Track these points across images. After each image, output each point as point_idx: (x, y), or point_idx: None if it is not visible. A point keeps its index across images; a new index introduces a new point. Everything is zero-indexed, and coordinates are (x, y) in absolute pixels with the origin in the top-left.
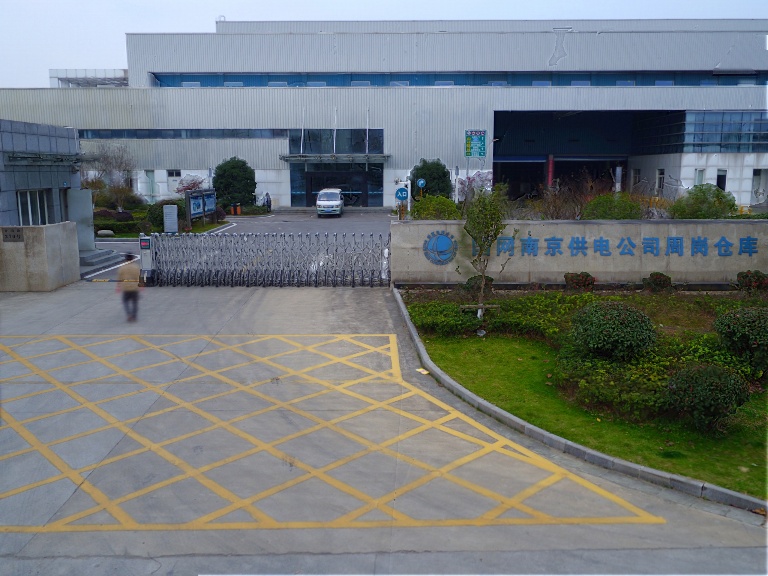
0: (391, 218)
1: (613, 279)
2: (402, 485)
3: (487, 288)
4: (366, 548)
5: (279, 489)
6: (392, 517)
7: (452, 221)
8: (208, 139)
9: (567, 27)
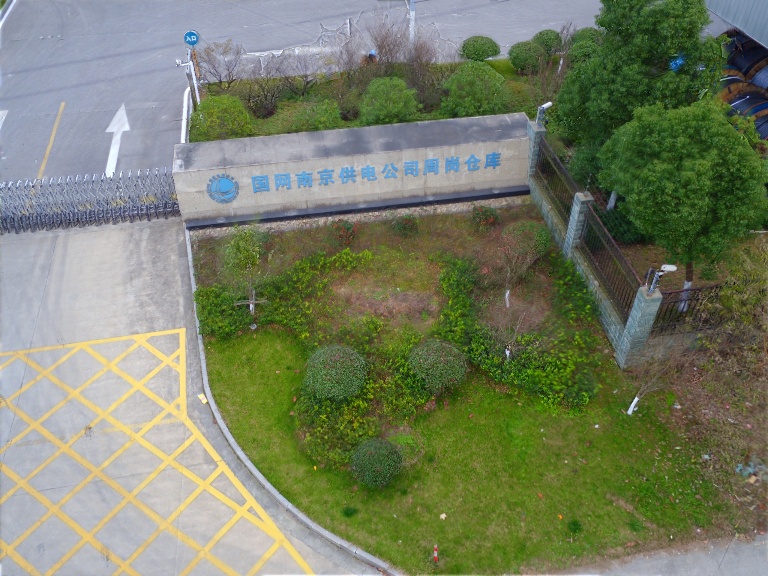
0: None
1: (379, 198)
2: (179, 573)
3: (263, 250)
4: None
5: None
6: None
7: (233, 150)
8: None
9: None
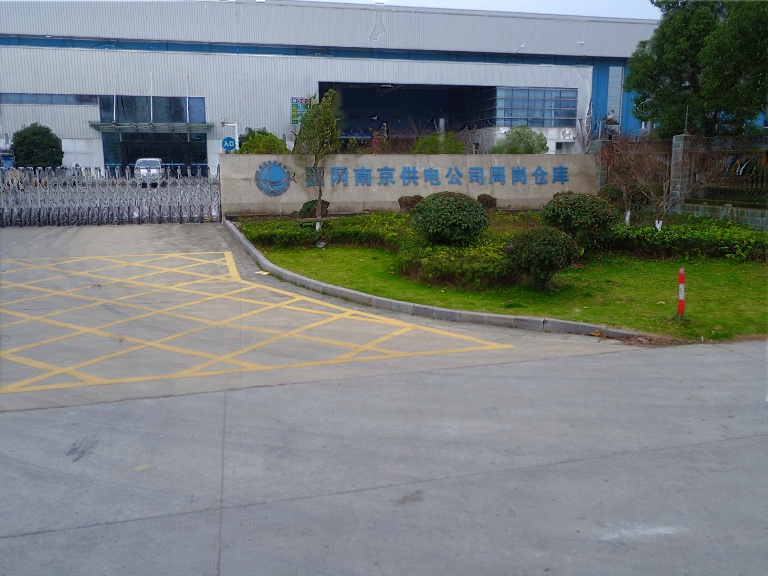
0: None
1: None
2: (249, 344)
3: (323, 211)
4: (214, 388)
5: (108, 357)
6: (240, 366)
7: None
8: (2, 104)
9: (385, 2)
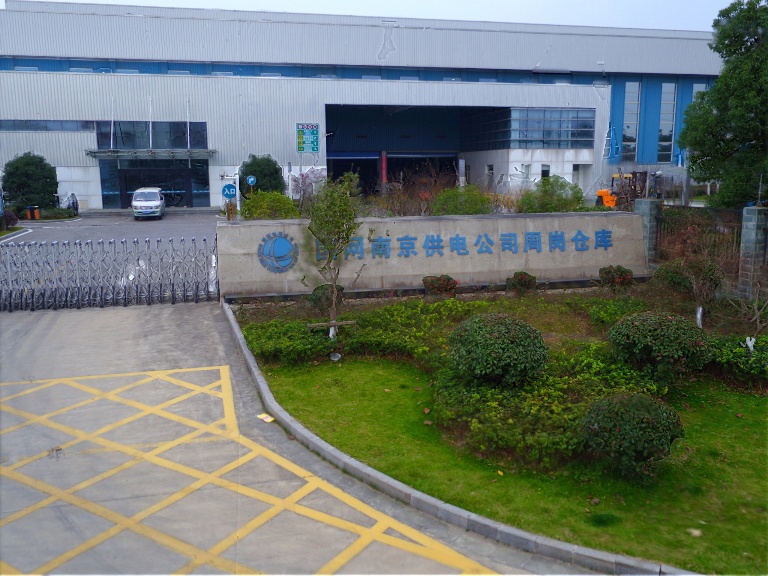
0: (219, 219)
1: (472, 280)
2: None
3: (337, 299)
4: None
5: None
6: None
7: (290, 220)
8: None
9: (395, 20)
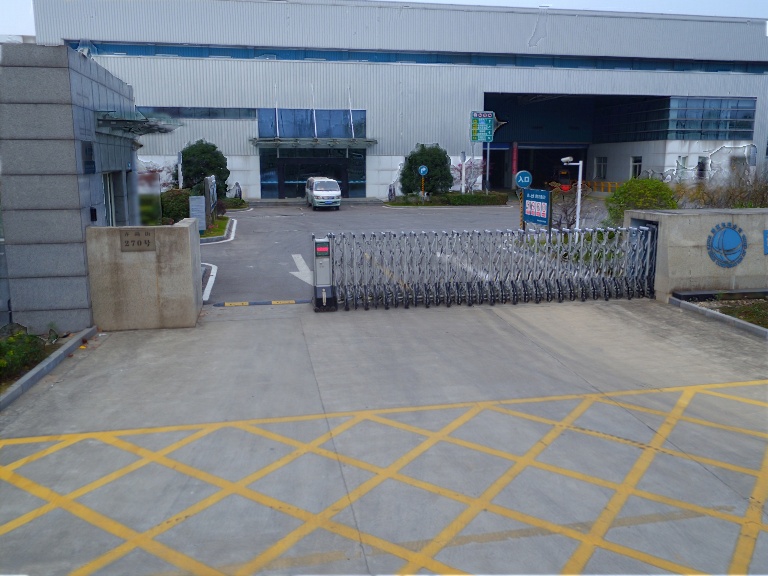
0: (398, 210)
1: None
2: None
3: None
4: None
5: None
6: None
7: (712, 210)
8: (160, 119)
9: (551, 5)
